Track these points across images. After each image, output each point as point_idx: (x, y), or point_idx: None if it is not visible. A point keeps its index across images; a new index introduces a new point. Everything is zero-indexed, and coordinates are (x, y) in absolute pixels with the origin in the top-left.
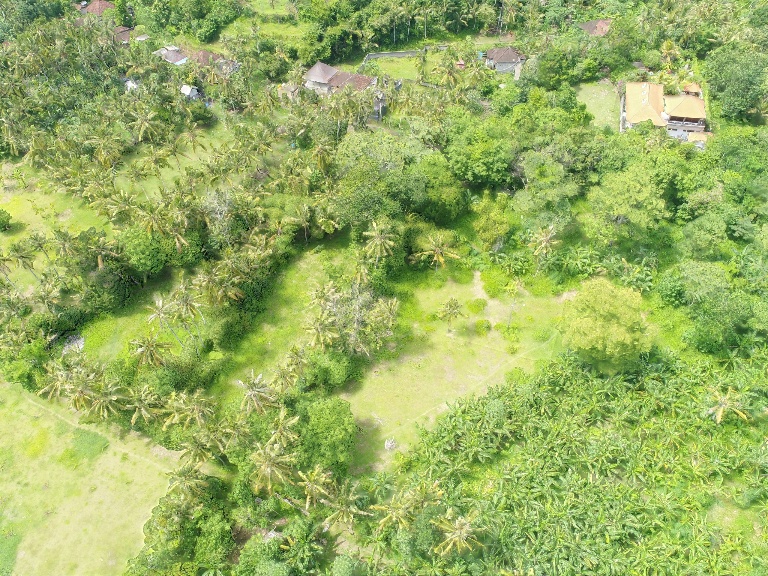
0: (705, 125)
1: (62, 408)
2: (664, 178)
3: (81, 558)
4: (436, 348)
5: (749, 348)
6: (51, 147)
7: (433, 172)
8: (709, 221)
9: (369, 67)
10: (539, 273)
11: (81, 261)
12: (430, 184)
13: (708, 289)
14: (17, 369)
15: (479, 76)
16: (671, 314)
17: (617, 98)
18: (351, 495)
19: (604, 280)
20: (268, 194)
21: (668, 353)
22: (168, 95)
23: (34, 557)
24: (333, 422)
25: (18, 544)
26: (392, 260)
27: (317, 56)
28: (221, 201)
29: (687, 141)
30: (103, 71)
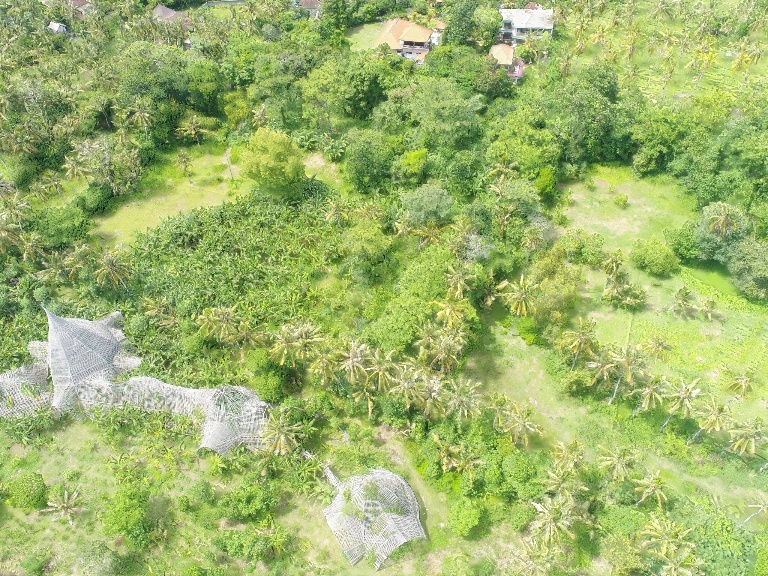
0: (429, 48)
1: None
2: (365, 77)
3: None
4: (177, 193)
5: (387, 187)
6: None
7: (199, 72)
8: (386, 105)
9: (202, 11)
10: None
11: None
12: (191, 78)
13: None
14: None
15: (271, 12)
16: None
17: None
18: (64, 260)
19: (267, 128)
20: (82, 91)
21: (330, 190)
22: (34, 27)
23: None
24: (65, 218)
25: None
26: (156, 132)
27: (163, 2)
28: (37, 90)
29: None
30: None
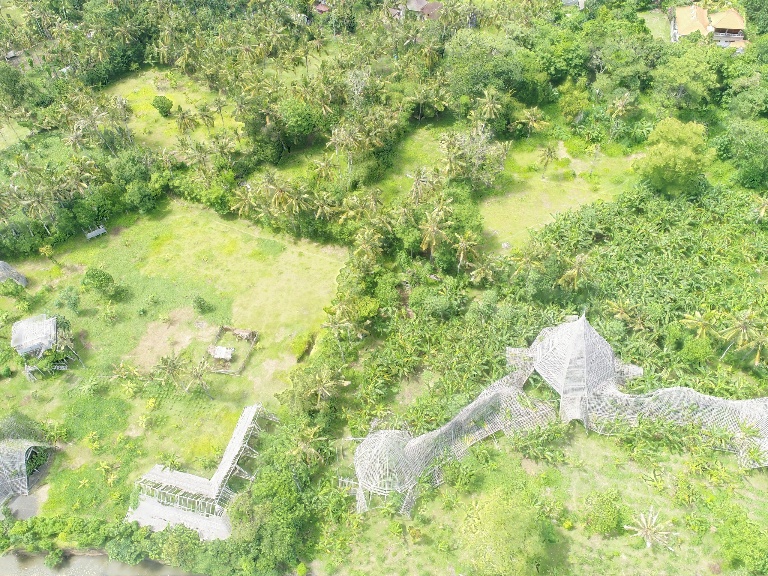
0: (744, 35)
1: (244, 226)
2: (714, 65)
3: (282, 311)
4: (534, 188)
5: None
6: (204, 50)
7: None
8: (751, 94)
9: None
10: (611, 141)
11: (255, 118)
12: (526, 68)
13: (752, 135)
14: (213, 193)
15: (553, 0)
16: (720, 166)
17: (667, 22)
18: None
19: None
20: (389, 82)
21: (720, 185)
22: (289, 18)
23: (246, 310)
24: (470, 215)
25: (232, 304)
26: (496, 125)
27: None
28: (357, 82)
29: (729, 46)
30: (229, 1)
